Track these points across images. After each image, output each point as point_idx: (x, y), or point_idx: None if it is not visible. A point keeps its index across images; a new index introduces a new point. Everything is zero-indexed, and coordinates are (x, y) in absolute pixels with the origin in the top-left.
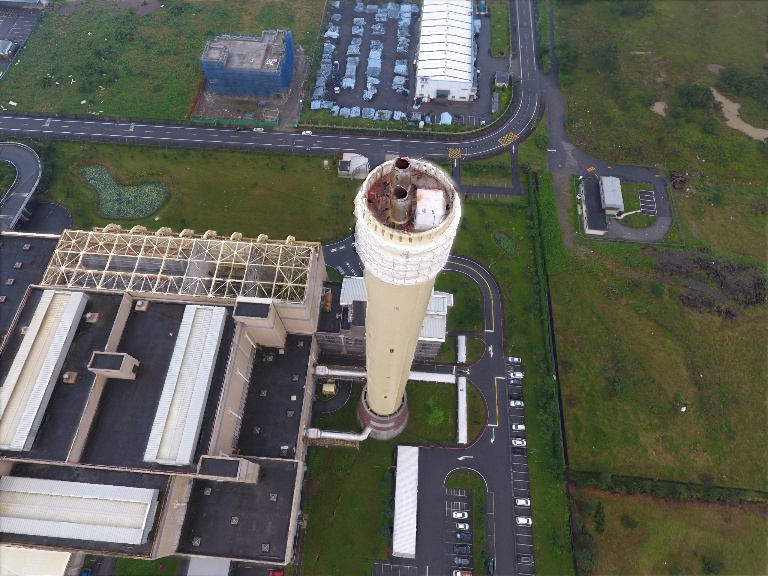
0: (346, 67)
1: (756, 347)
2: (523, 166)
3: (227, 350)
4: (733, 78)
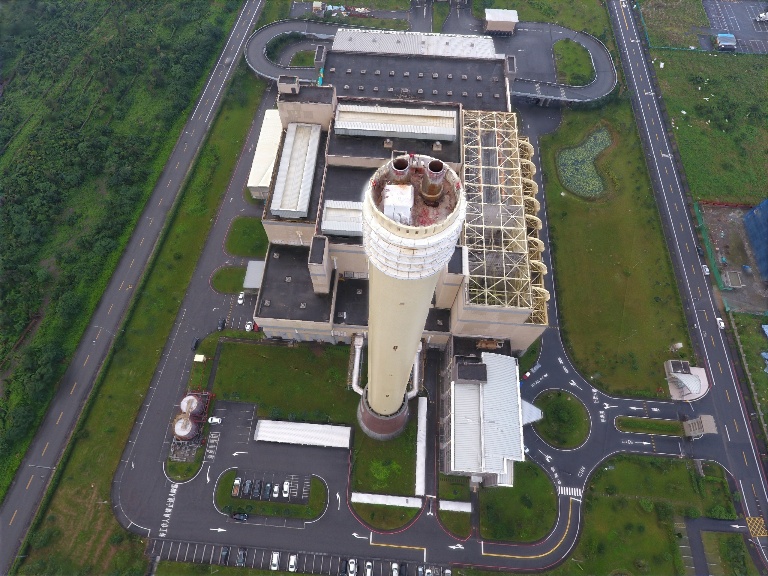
0: None
1: None
2: None
3: None
4: None
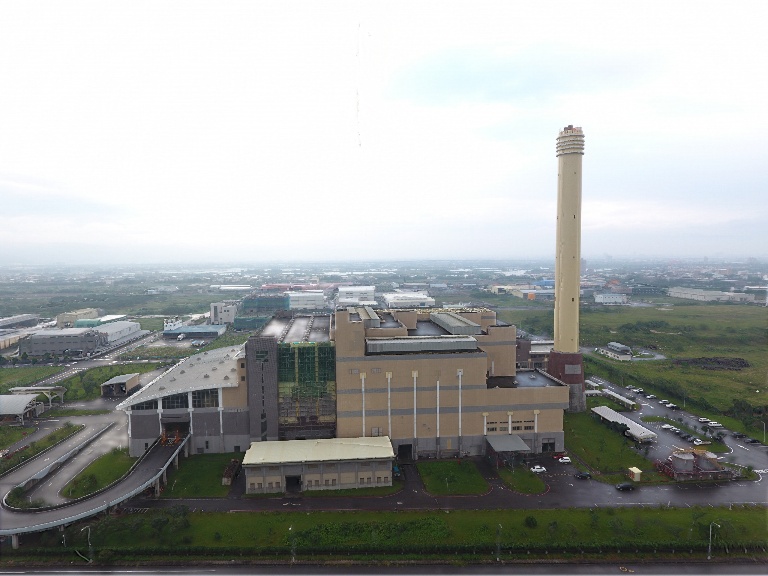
0: None
1: (767, 375)
2: None
3: None
4: (641, 323)
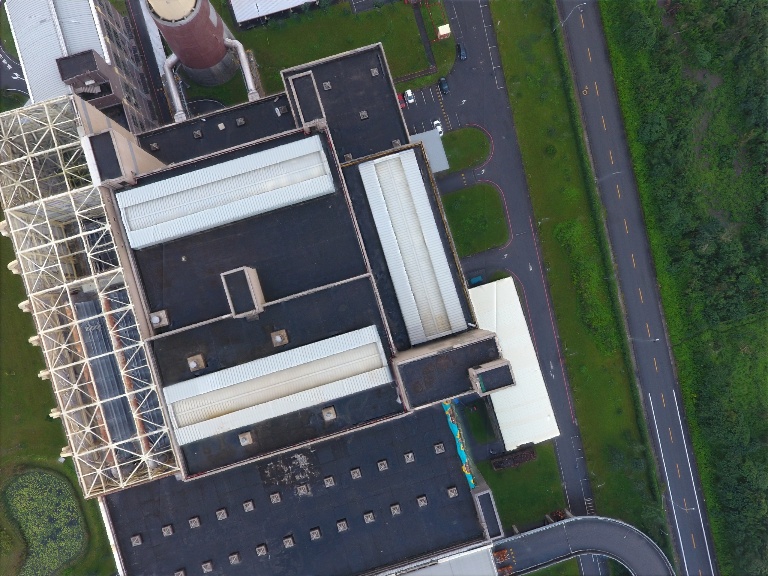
0: None
1: None
2: None
3: (176, 175)
4: None
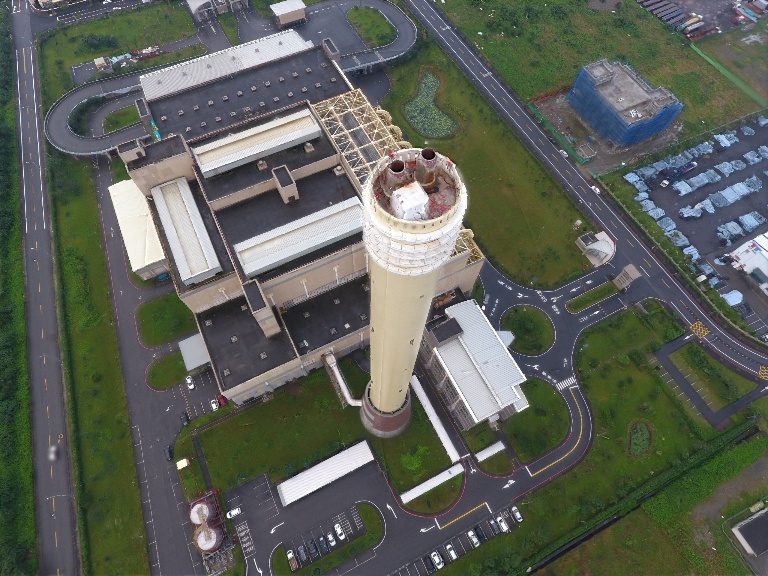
0: (699, 175)
1: None
2: (751, 409)
3: (343, 246)
4: None
